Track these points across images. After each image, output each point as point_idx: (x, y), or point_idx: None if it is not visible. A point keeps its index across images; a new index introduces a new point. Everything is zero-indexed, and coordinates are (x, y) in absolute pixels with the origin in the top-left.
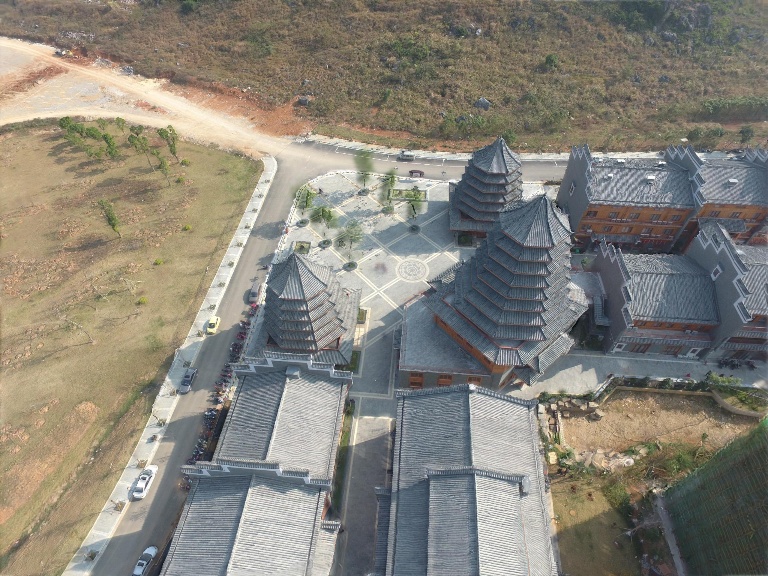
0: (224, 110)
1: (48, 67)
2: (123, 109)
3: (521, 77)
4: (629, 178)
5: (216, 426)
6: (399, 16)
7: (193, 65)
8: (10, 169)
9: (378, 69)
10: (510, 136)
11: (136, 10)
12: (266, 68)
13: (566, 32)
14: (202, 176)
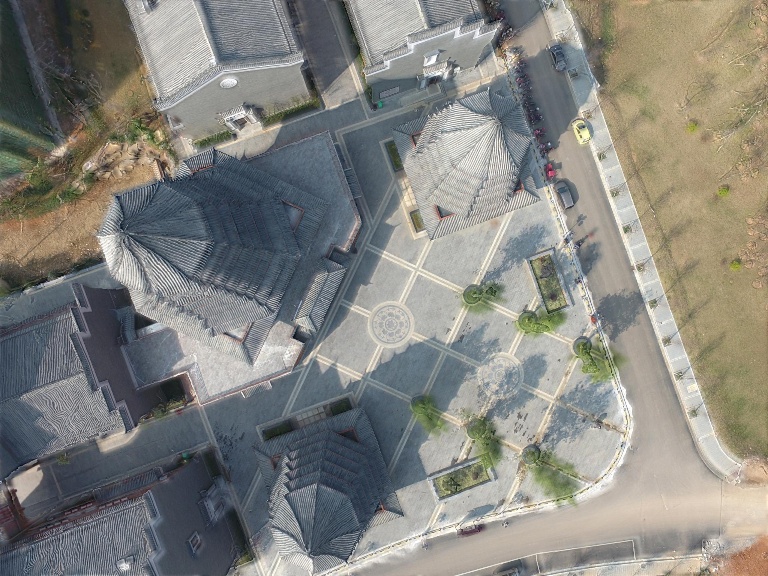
0: None
1: None
2: None
3: None
4: (93, 574)
5: None
6: None
7: None
8: None
9: None
10: None
11: None
12: None
13: None
14: None
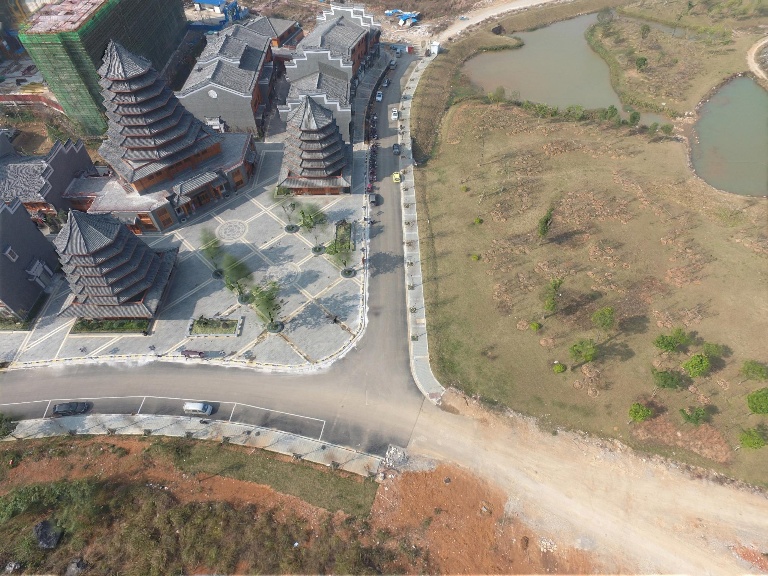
0: None
1: None
2: None
3: None
4: None
5: None
6: None
7: None
8: None
9: None
10: None
11: None
12: None
13: None
14: (512, 339)
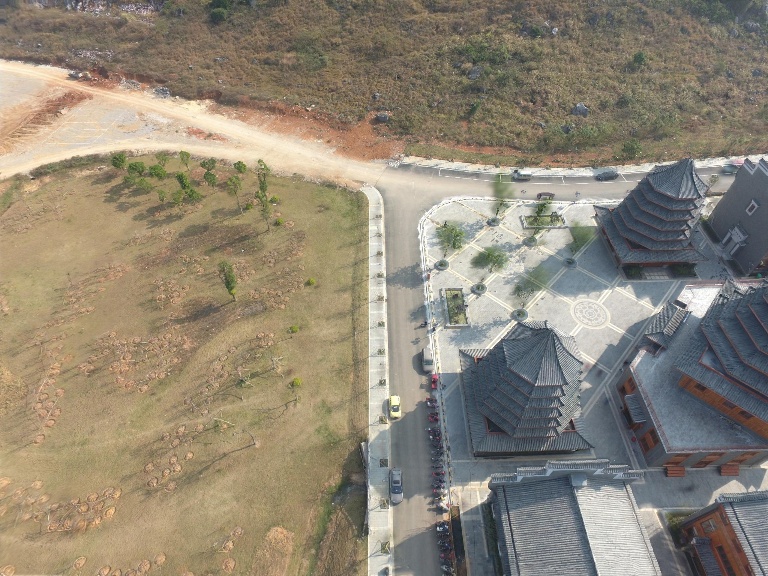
0: (292, 133)
1: (67, 93)
2: (174, 139)
3: (611, 78)
4: None
5: (457, 545)
6: (464, 17)
7: (238, 82)
8: (65, 222)
9: (455, 77)
10: (636, 147)
11: (161, 22)
12: (326, 82)
13: (648, 27)
14: (302, 215)
